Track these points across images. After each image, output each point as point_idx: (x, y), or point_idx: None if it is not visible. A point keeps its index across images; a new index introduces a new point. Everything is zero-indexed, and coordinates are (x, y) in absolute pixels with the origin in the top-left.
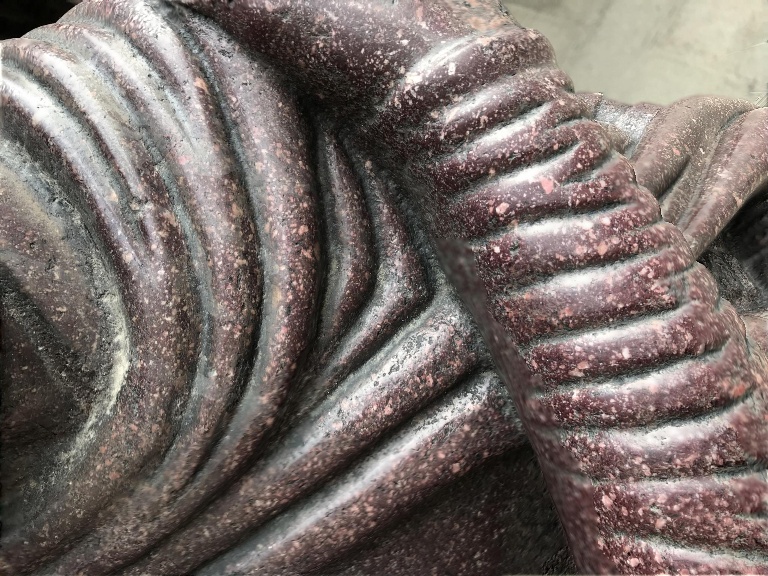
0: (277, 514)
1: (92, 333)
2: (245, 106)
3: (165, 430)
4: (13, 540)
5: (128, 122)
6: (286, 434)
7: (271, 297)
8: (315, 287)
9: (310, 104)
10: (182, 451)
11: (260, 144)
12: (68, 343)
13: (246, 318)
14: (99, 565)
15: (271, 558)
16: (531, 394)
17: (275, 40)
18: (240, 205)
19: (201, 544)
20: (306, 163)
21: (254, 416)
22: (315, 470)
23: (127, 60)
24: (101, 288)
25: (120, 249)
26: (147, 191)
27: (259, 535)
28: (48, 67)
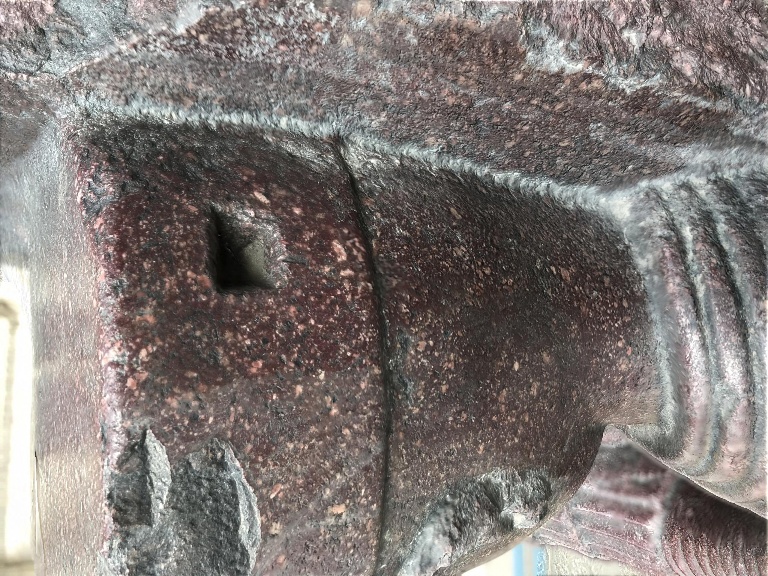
0: None
1: None
2: None
3: None
4: None
5: None
6: None
7: None
8: None
9: None
10: None
11: None
12: None
13: None
14: None
15: None
16: (742, 540)
17: None
18: None
19: None
20: None
21: None
22: None
23: (765, 493)
24: None
25: None
26: None
27: None
28: (720, 466)
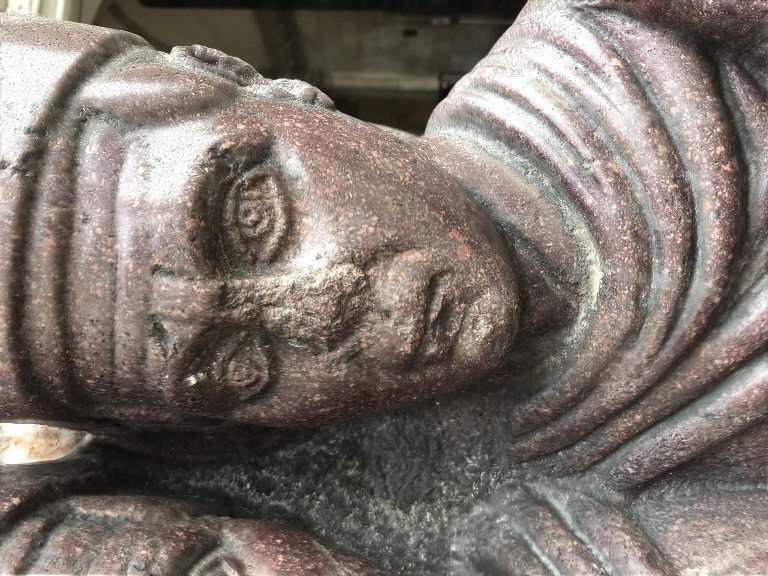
0: (735, 370)
1: (571, 257)
2: (653, 67)
3: (637, 315)
4: (549, 393)
5: (568, 107)
6: (732, 309)
7: (701, 207)
8: (738, 192)
9: (707, 46)
10: (652, 328)
11: (671, 93)
12: (558, 266)
13: (684, 227)
14: (606, 408)
15: (736, 403)
16: None
17: (670, 10)
18: (664, 144)
19: (676, 394)
20: (713, 96)
21: (703, 298)
22: (763, 334)
23: (558, 62)
24: (571, 225)
25: (582, 197)
26: (593, 152)
27: (722, 387)
28: (508, 86)
